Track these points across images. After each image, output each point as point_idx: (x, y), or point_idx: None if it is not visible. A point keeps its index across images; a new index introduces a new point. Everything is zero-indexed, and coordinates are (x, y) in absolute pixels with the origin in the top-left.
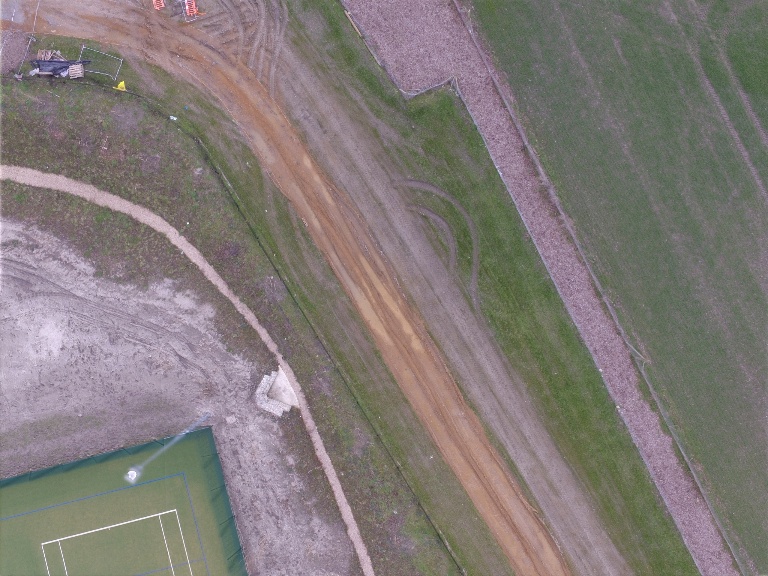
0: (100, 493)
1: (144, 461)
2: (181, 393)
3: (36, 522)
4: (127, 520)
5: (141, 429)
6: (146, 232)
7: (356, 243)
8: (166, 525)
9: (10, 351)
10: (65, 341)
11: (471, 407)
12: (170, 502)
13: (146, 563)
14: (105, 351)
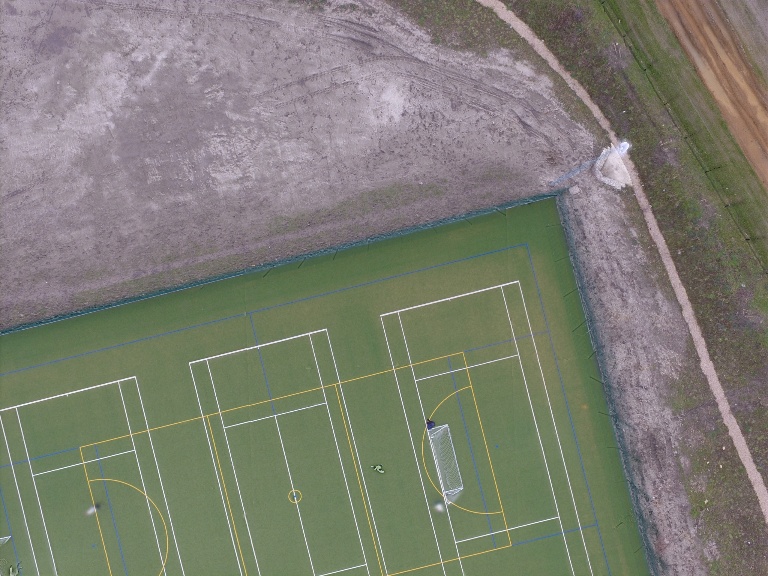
0: (441, 264)
1: (486, 231)
2: (524, 161)
3: (375, 293)
4: (468, 291)
5: (483, 198)
6: (473, 6)
7: (701, 11)
8: (508, 297)
9: (350, 116)
10: (406, 106)
11: None
12: (513, 273)
13: (488, 335)
14: (447, 117)
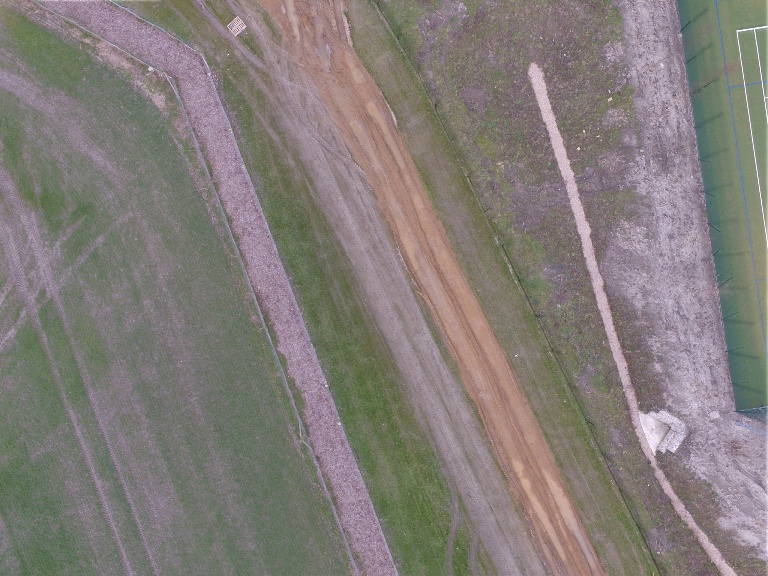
0: None
1: None
2: (763, 448)
3: None
4: None
5: None
6: None
7: (569, 575)
8: None
9: None
10: None
11: (471, 400)
12: None
13: None
14: None
